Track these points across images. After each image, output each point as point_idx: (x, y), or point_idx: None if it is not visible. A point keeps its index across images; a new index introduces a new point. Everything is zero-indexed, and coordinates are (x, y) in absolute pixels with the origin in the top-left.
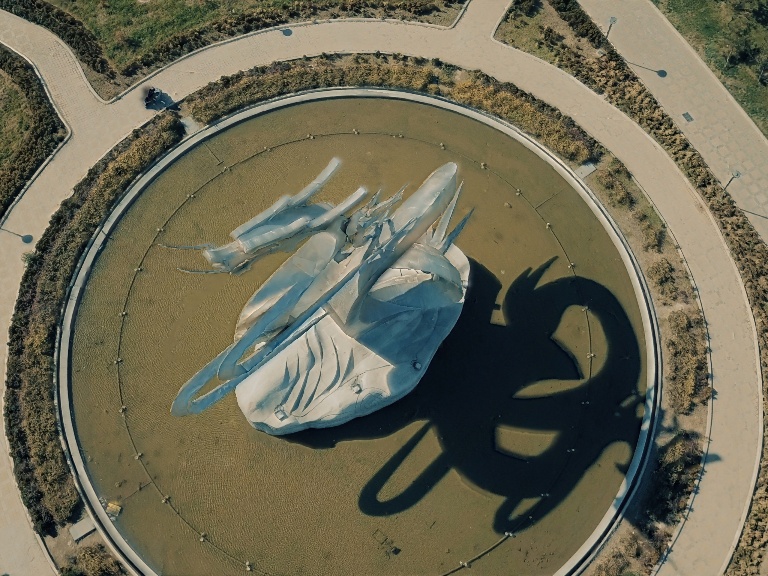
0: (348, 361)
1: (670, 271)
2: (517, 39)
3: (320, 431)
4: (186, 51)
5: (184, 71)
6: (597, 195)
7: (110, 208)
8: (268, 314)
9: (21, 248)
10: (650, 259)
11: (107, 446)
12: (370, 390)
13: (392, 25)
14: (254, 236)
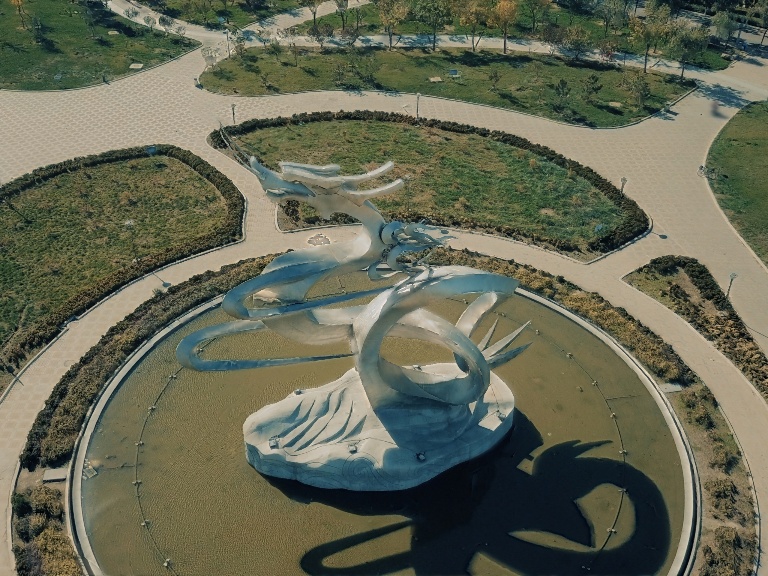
0: (357, 424)
1: (733, 491)
2: (643, 285)
3: (304, 487)
4: None
5: (350, 231)
6: (675, 409)
7: None
8: (287, 270)
9: (158, 288)
10: (714, 475)
11: (121, 428)
12: (365, 454)
13: (534, 250)
14: (297, 170)
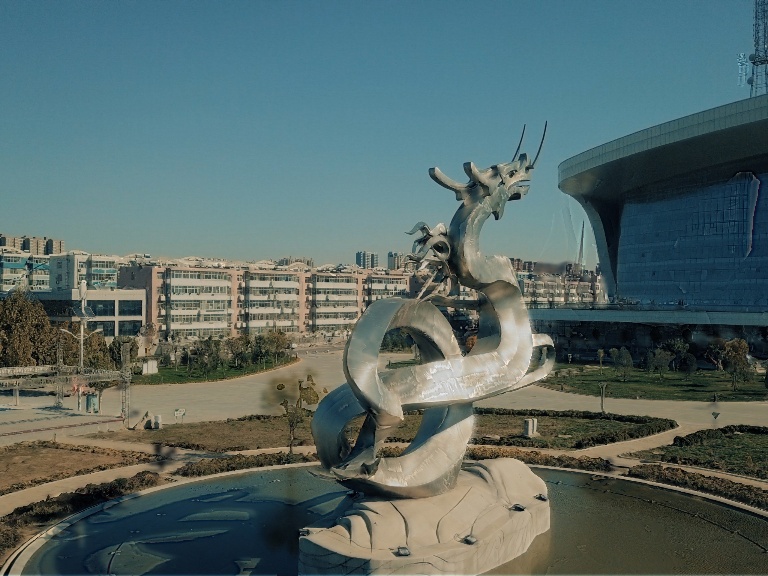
0: None
1: None
2: None
3: None
4: None
5: None
6: None
7: None
8: None
9: None
10: None
11: None
12: None
13: None
14: None
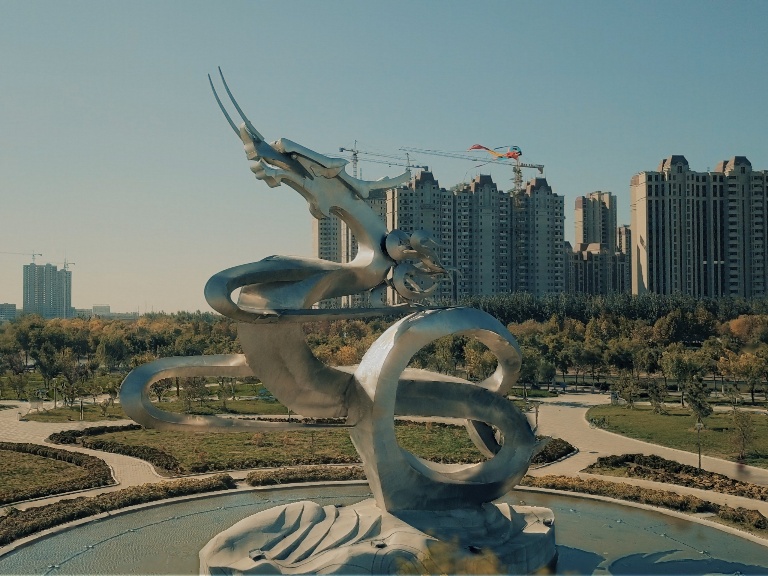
0: (372, 524)
1: None
2: None
3: None
4: (260, 466)
5: None
6: None
7: (127, 506)
8: (284, 262)
9: None
10: None
11: None
12: (399, 546)
13: None
14: None
